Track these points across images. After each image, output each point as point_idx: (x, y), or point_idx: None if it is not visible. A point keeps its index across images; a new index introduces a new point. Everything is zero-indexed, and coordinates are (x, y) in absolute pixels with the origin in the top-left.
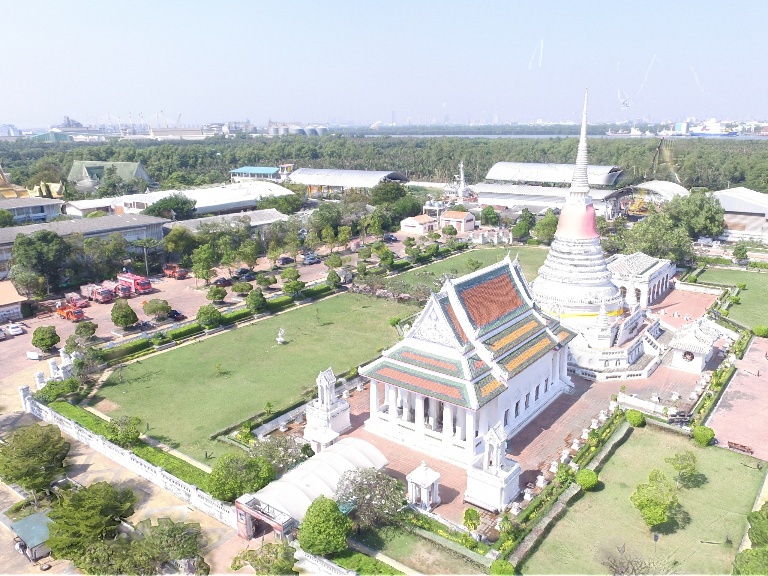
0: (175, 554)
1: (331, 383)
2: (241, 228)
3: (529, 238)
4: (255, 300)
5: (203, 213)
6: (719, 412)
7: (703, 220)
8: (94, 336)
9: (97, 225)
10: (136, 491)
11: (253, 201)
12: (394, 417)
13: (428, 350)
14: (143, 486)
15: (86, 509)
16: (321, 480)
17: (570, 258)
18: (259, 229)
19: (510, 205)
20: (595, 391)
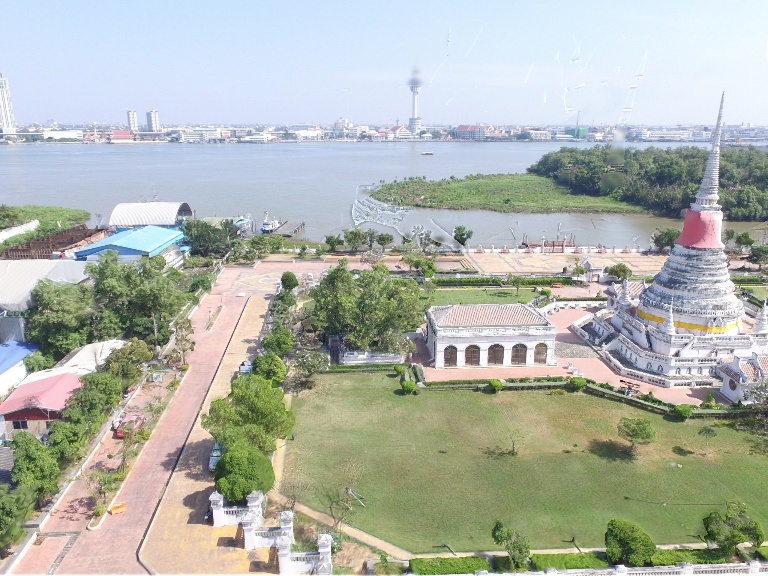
0: None
1: None
2: None
3: None
4: None
5: None
6: None
7: None
8: None
9: None
10: None
11: None
12: None
13: None
14: None
15: None
16: None
17: None
18: None
19: None
20: None
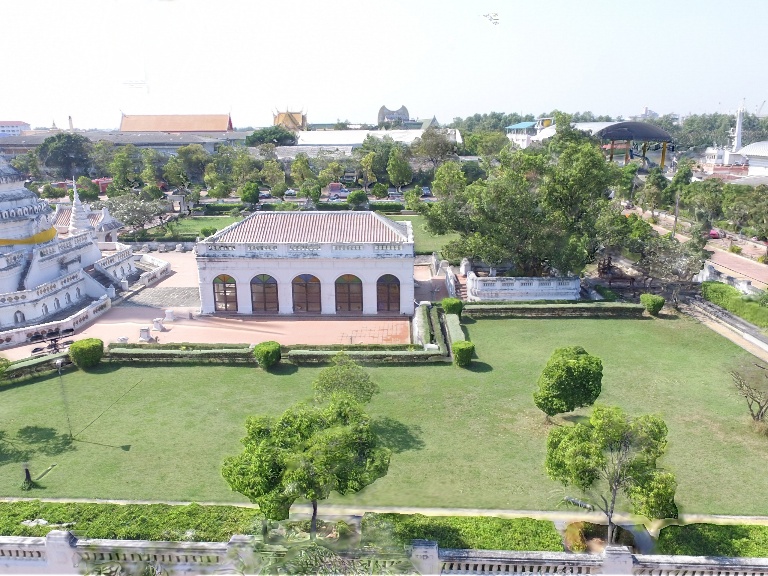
0: None
1: None
2: (249, 155)
3: None
4: None
5: None
6: None
7: None
8: None
9: (145, 139)
10: None
11: None
12: None
13: None
14: None
15: None
16: None
17: None
18: None
19: None
20: None
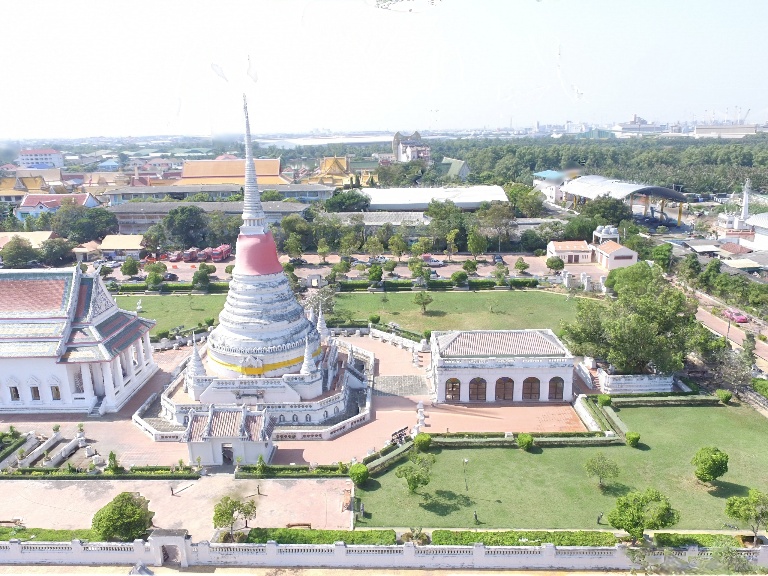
0: None
1: None
2: (343, 225)
3: None
4: None
5: (394, 210)
6: (38, 483)
7: None
8: (112, 277)
9: None
10: None
11: None
12: None
13: None
14: None
15: None
16: None
17: None
18: (365, 228)
19: None
20: (103, 424)
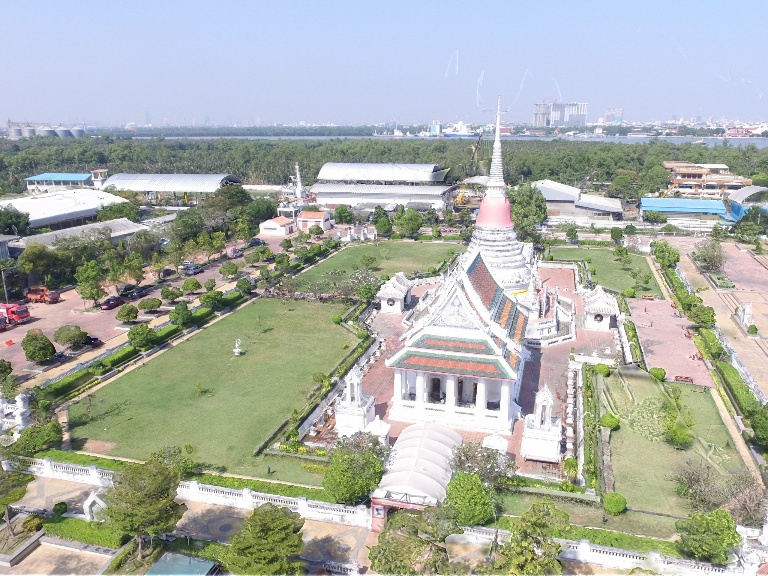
0: (419, 543)
1: (361, 379)
2: (105, 241)
3: (392, 233)
4: (183, 314)
5: None
6: (649, 357)
7: (535, 208)
8: None
9: None
10: (226, 519)
11: (86, 211)
12: (422, 402)
13: (451, 335)
14: (229, 513)
15: (277, 531)
16: (432, 463)
17: (496, 245)
18: (123, 241)
19: (351, 203)
20: (547, 356)
